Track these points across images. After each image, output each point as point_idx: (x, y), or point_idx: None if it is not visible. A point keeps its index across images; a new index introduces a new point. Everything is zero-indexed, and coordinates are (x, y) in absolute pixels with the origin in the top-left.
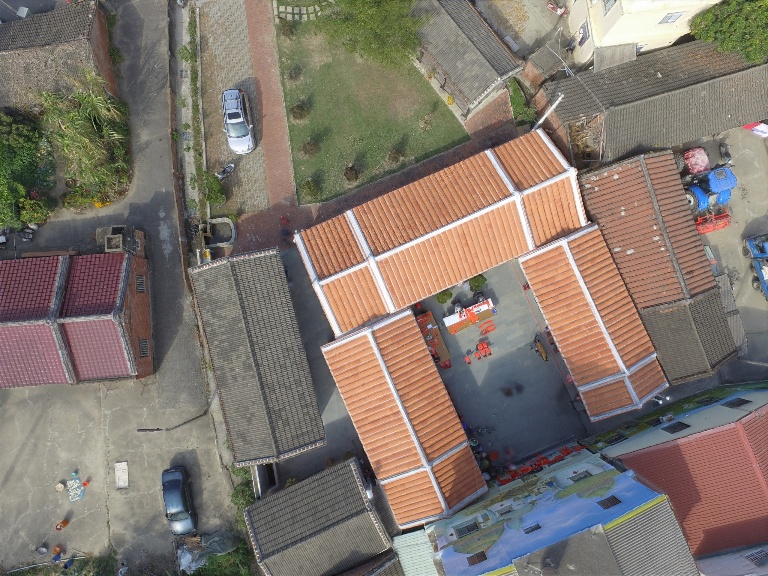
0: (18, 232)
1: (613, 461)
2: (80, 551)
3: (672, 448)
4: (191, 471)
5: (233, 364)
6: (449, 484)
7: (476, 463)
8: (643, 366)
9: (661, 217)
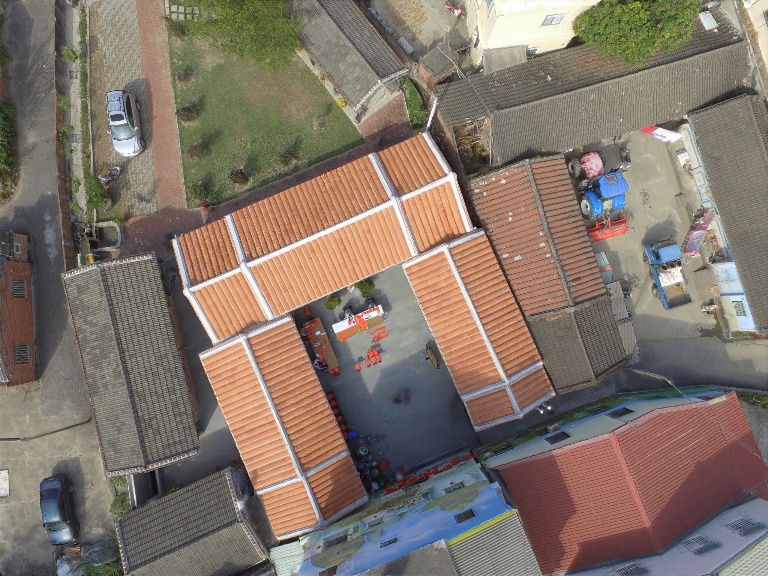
0: None
1: (491, 472)
2: None
3: (548, 459)
4: (73, 479)
5: (104, 372)
6: (325, 495)
7: (356, 473)
8: (528, 375)
9: (546, 223)
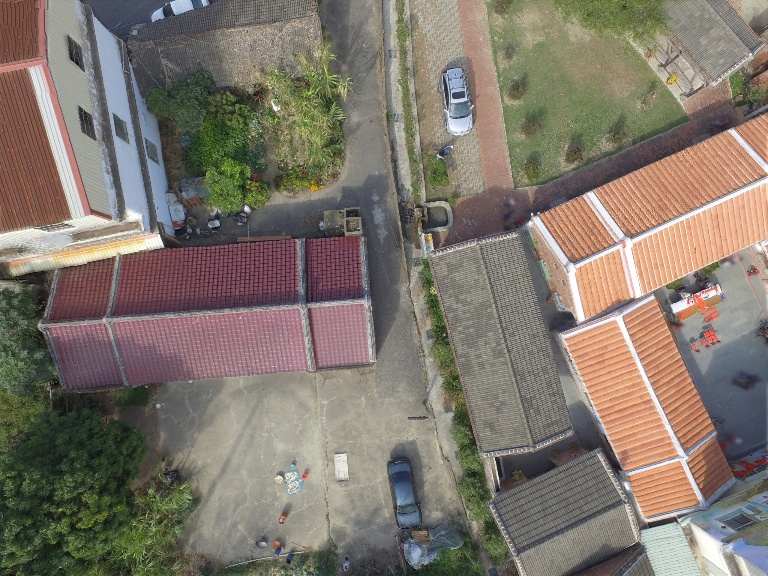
0: (235, 216)
1: None
2: (300, 545)
3: None
4: (412, 463)
5: (480, 351)
6: (701, 475)
7: None
8: None
9: None
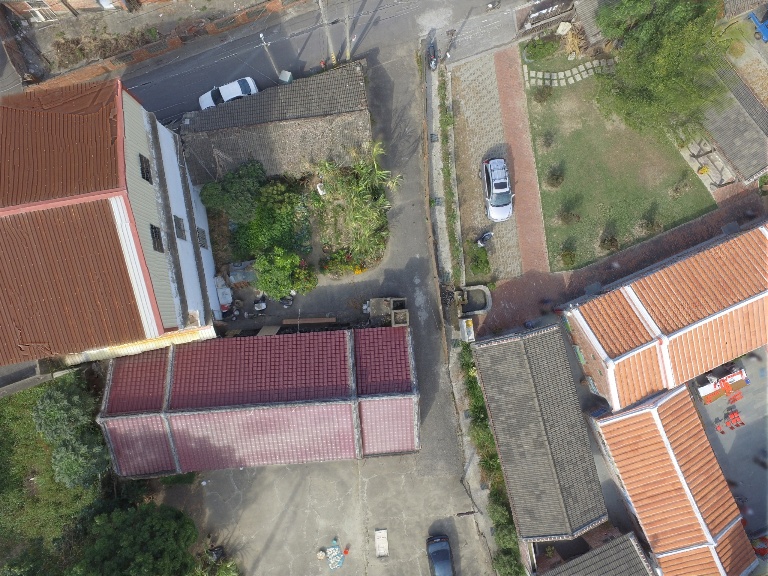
0: (281, 299)
1: None
2: None
3: None
4: (449, 539)
5: (521, 441)
6: (728, 559)
7: None
8: None
9: None
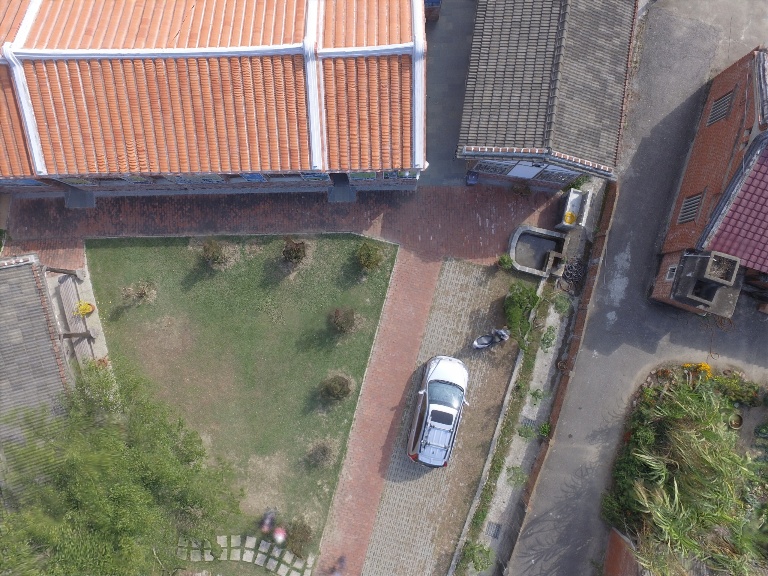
0: None
1: None
2: None
3: None
4: None
5: None
6: None
7: None
8: None
9: None
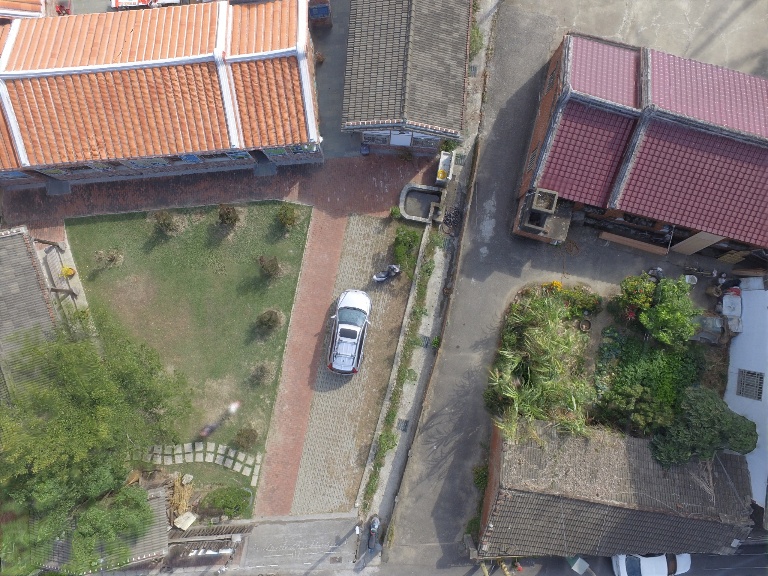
0: None
1: None
2: None
3: None
4: None
5: None
6: None
7: None
8: None
9: None
